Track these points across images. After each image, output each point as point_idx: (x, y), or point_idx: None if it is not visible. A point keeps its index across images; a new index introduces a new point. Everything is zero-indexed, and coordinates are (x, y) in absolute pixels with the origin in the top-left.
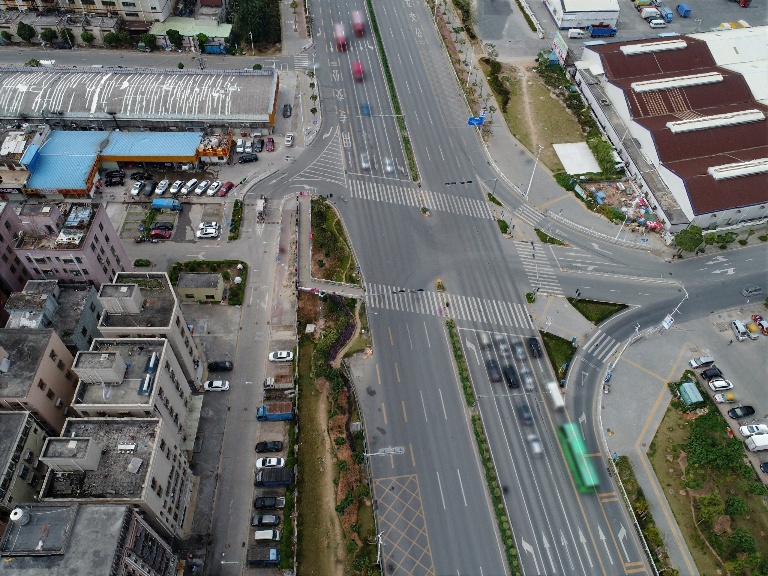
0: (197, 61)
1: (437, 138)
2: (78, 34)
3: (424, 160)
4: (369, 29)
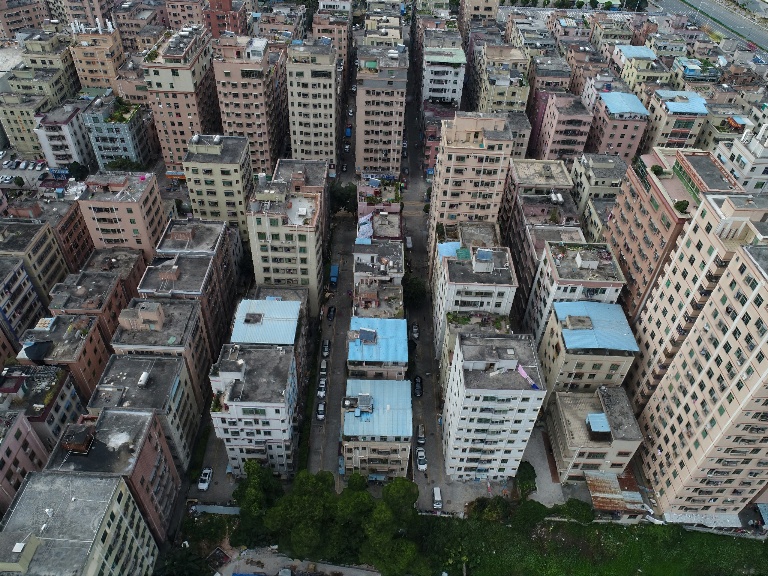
0: (622, 9)
1: (764, 42)
2: (540, 1)
3: (766, 48)
4: (687, 6)
